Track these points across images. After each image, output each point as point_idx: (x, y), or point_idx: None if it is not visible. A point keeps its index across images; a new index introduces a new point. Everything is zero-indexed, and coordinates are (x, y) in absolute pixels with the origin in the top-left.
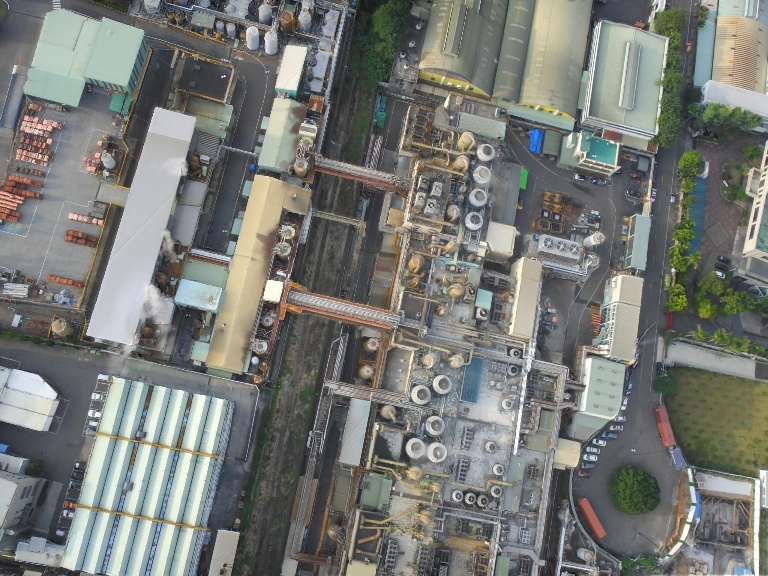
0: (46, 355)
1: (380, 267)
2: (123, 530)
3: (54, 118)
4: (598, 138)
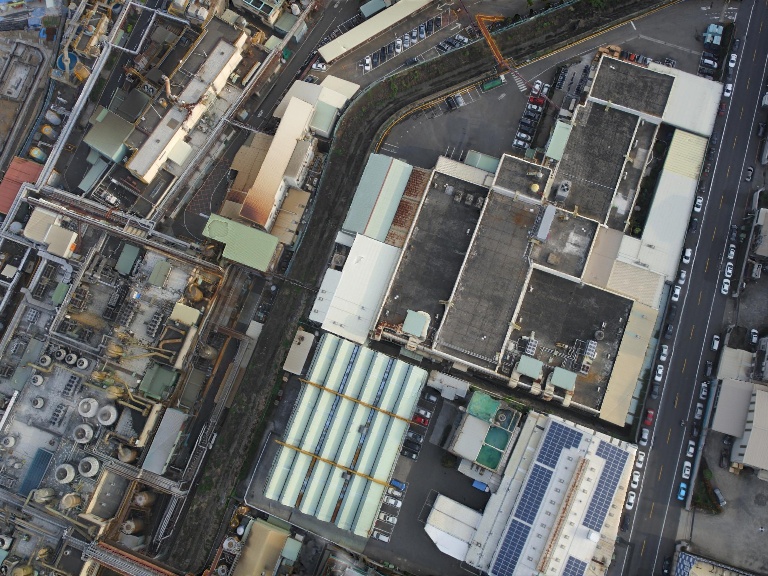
0: (436, 570)
1: None
2: (371, 392)
3: None
4: None
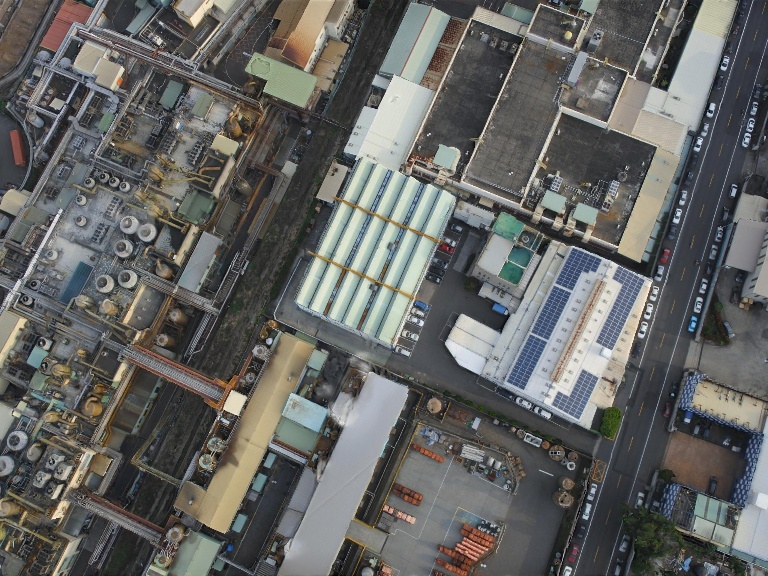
0: (454, 385)
1: (134, 417)
2: (401, 213)
3: None
4: None
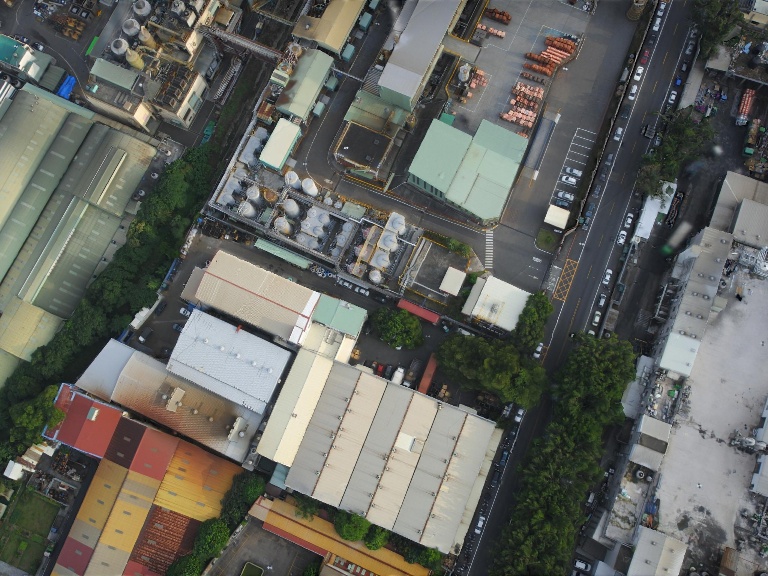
0: None
1: None
2: None
3: (506, 126)
4: (5, 62)
